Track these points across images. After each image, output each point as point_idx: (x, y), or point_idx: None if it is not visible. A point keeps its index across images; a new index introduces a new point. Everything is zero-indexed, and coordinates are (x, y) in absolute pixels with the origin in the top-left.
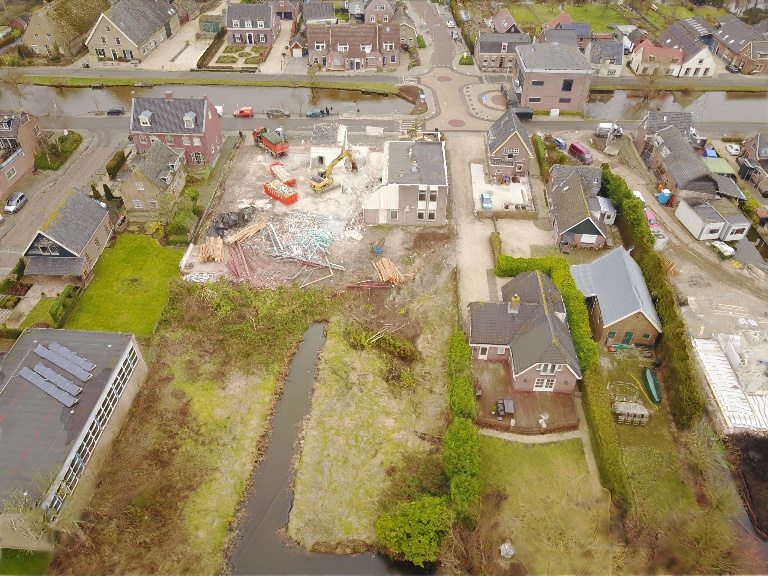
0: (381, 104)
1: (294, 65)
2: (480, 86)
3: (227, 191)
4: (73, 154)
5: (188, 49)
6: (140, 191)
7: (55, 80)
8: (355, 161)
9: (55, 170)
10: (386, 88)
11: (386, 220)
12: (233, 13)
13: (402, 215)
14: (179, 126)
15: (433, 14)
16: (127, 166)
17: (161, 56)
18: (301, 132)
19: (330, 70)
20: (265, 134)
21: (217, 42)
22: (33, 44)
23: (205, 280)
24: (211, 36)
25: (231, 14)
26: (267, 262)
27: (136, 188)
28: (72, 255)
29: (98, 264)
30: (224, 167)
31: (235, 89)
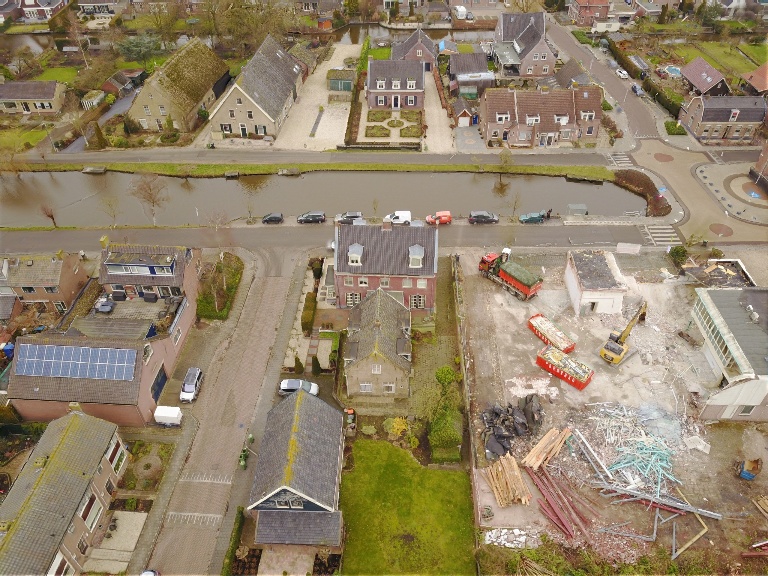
0: (595, 195)
1: (465, 139)
2: (715, 168)
3: (477, 359)
4: (239, 290)
5: (324, 117)
6: (375, 374)
7: (180, 170)
8: (626, 300)
9: (224, 319)
10: (597, 173)
11: (732, 415)
12: (376, 71)
13: (759, 410)
14: (401, 265)
15: (591, 59)
16: (321, 313)
17: (296, 129)
18: (526, 248)
19: (515, 147)
20: (505, 266)
21: (355, 106)
22: (141, 118)
23: (522, 544)
24: (345, 98)
25: (374, 73)
26: (599, 504)
27: (370, 371)
28: (323, 509)
29: (343, 503)
30: (458, 316)
31: (405, 176)
